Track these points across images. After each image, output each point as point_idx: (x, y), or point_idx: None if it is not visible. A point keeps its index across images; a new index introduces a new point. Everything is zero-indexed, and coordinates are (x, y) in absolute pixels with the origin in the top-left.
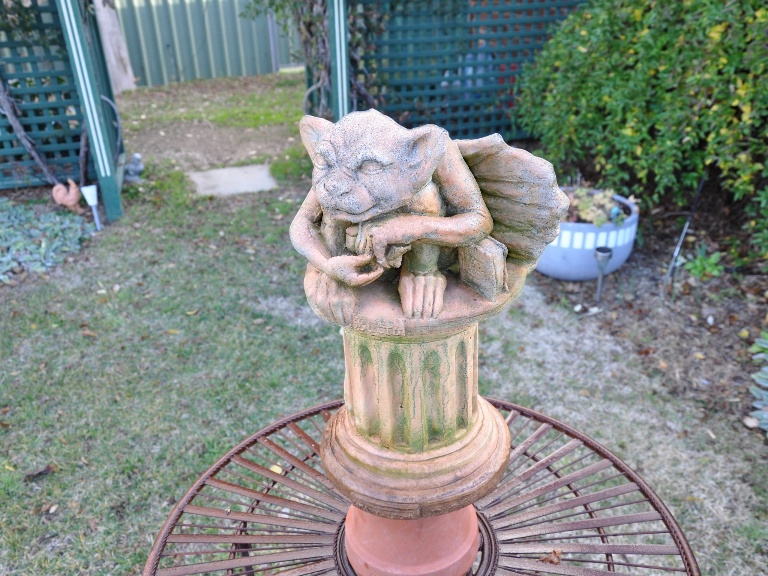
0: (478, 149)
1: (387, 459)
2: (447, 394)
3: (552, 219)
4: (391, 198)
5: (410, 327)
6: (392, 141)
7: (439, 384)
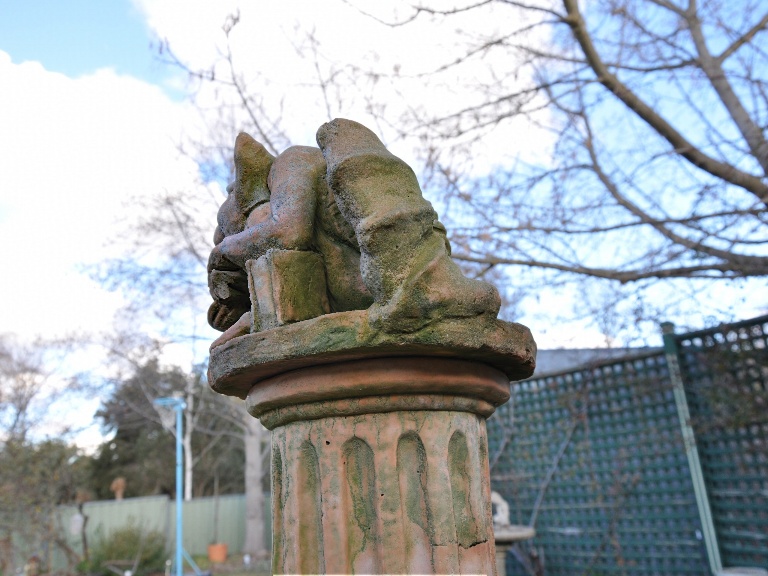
0: None
1: None
2: (285, 534)
3: None
4: None
5: None
6: None
7: None
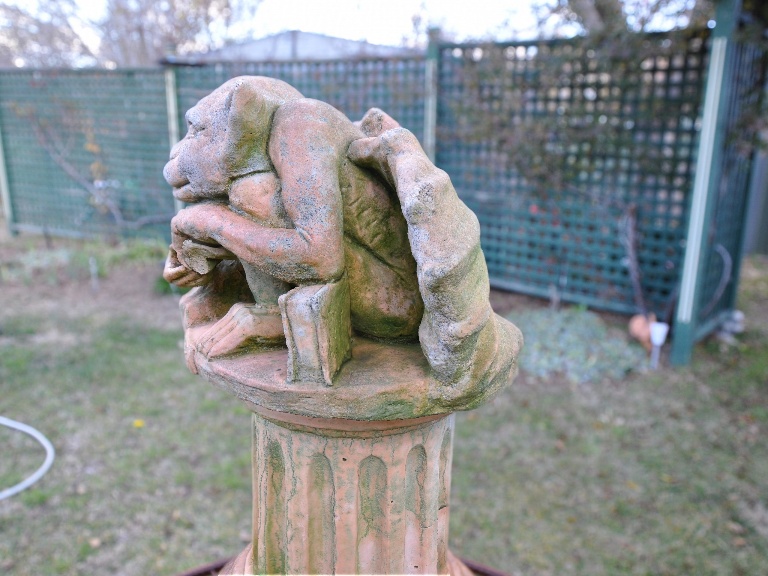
0: (370, 151)
1: (243, 572)
2: (291, 522)
3: (424, 290)
4: (194, 173)
5: (196, 361)
6: (219, 103)
7: (285, 499)
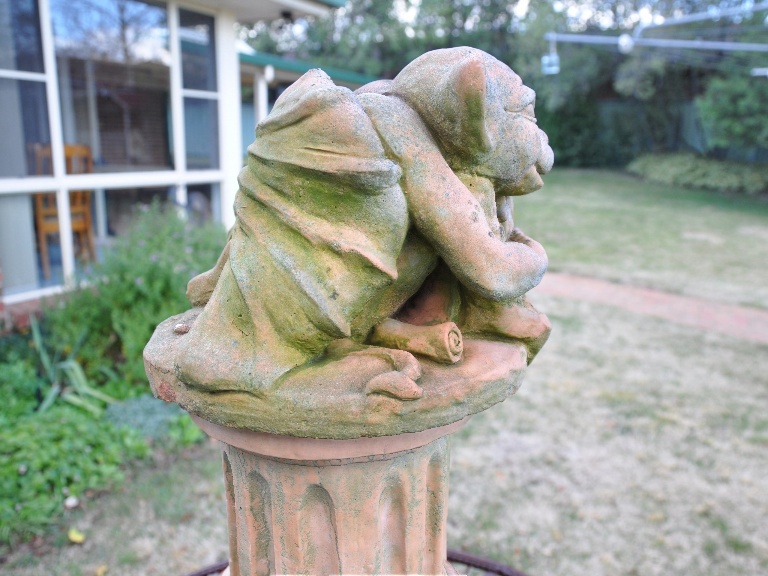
0: None
1: (448, 572)
2: None
3: None
4: None
5: None
6: None
7: None
